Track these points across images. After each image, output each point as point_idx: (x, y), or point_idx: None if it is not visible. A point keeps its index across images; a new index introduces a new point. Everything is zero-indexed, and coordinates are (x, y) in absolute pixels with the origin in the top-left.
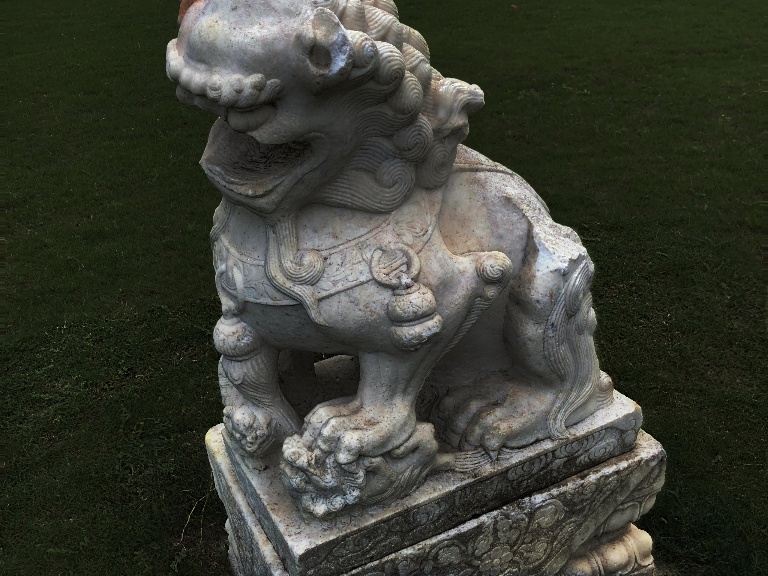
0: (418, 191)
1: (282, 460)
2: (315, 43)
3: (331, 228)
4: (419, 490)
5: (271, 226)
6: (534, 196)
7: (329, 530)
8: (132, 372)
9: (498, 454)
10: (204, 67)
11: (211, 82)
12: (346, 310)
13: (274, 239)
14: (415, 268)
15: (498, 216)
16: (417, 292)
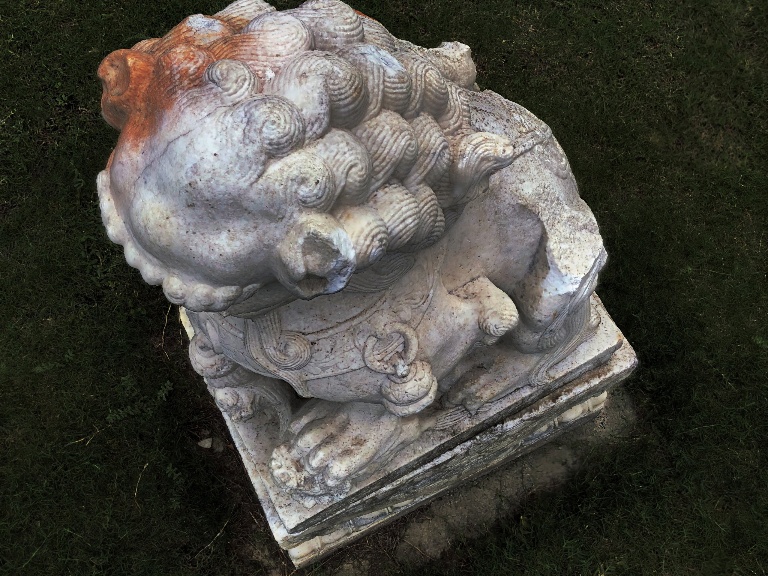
0: (420, 252)
1: (270, 463)
2: (306, 273)
3: (319, 310)
4: (400, 454)
5: None
6: (554, 175)
7: None
8: (73, 101)
9: (478, 409)
10: (157, 262)
11: (170, 291)
12: (336, 391)
13: (253, 326)
14: (413, 353)
15: (509, 229)
16: (413, 380)
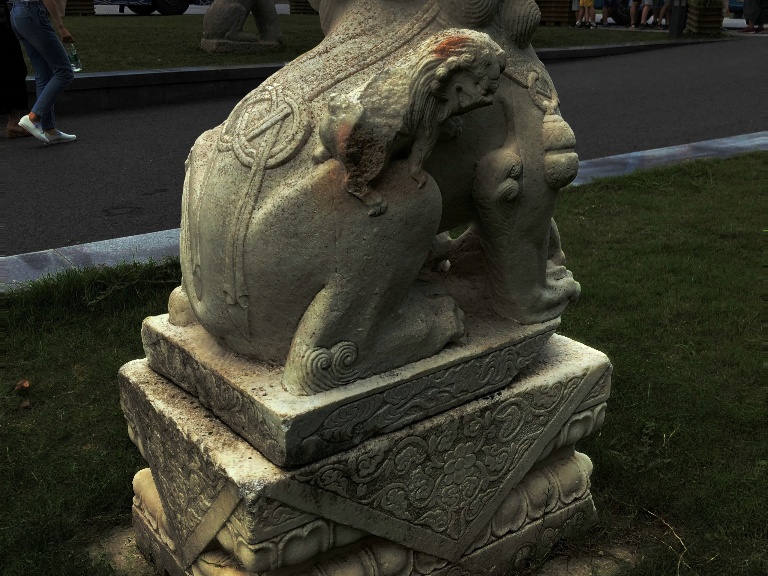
0: None
1: None
2: None
3: None
4: None
5: None
6: None
7: None
8: None
9: None
10: None
11: None
12: None
13: None
14: None
15: None
16: None
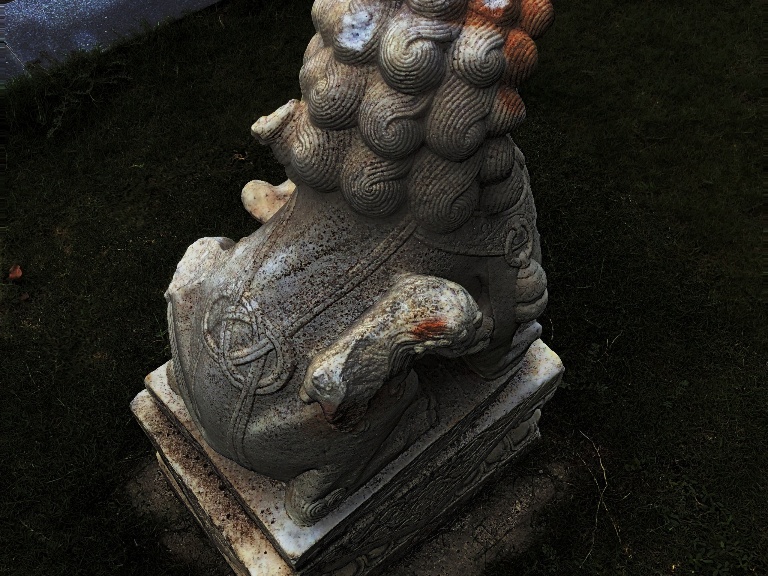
0: None
1: None
2: None
3: None
4: None
5: None
6: None
7: None
8: None
9: None
10: None
11: None
12: None
13: None
14: None
15: None
16: None
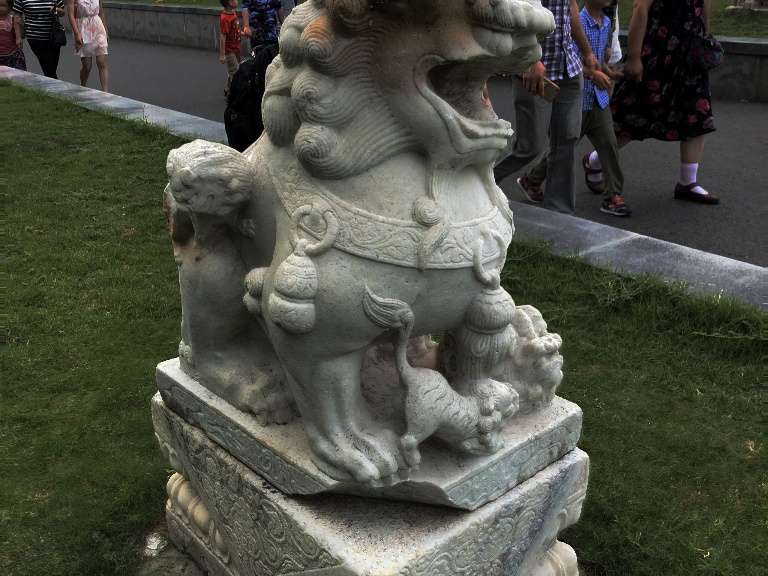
0: None
1: (545, 364)
2: None
3: None
4: None
5: None
6: None
7: None
8: None
9: None
10: None
11: None
12: None
13: None
14: None
15: None
16: None
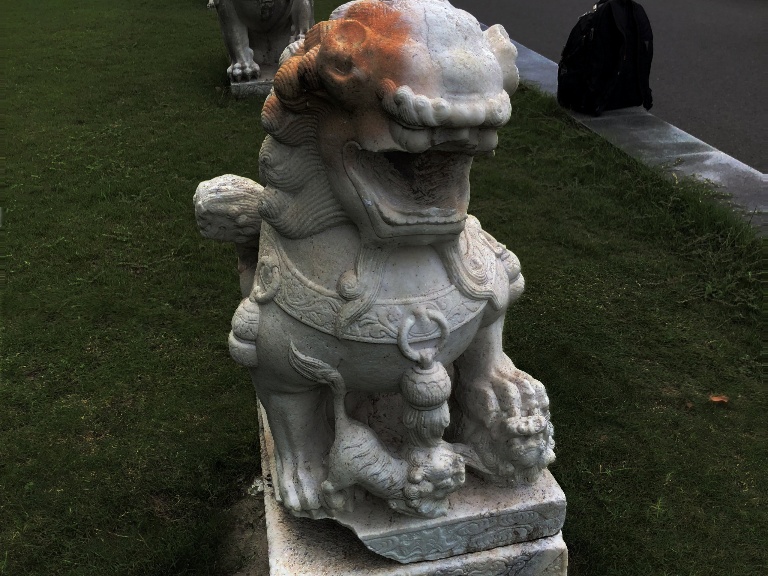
0: None
1: (515, 446)
2: None
3: None
4: None
5: (454, 247)
6: None
7: (545, 474)
8: None
9: None
10: (477, 96)
11: (497, 105)
12: (503, 287)
13: (457, 258)
14: None
15: None
16: None
